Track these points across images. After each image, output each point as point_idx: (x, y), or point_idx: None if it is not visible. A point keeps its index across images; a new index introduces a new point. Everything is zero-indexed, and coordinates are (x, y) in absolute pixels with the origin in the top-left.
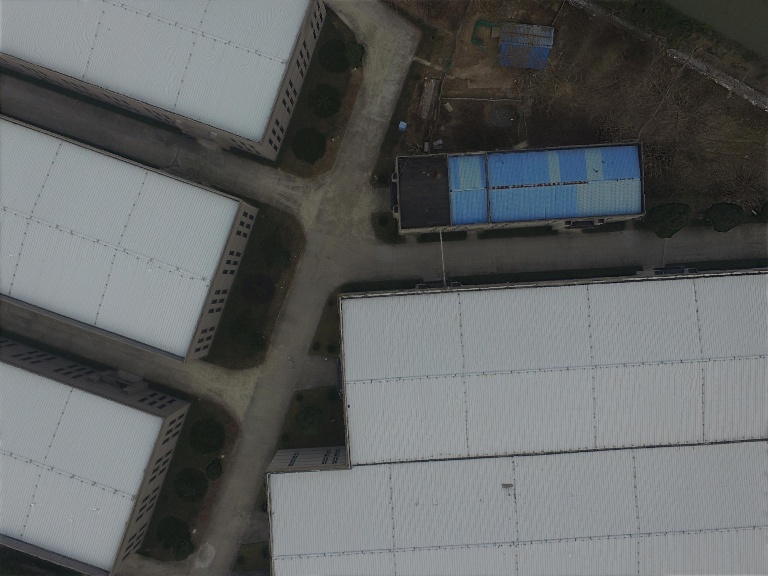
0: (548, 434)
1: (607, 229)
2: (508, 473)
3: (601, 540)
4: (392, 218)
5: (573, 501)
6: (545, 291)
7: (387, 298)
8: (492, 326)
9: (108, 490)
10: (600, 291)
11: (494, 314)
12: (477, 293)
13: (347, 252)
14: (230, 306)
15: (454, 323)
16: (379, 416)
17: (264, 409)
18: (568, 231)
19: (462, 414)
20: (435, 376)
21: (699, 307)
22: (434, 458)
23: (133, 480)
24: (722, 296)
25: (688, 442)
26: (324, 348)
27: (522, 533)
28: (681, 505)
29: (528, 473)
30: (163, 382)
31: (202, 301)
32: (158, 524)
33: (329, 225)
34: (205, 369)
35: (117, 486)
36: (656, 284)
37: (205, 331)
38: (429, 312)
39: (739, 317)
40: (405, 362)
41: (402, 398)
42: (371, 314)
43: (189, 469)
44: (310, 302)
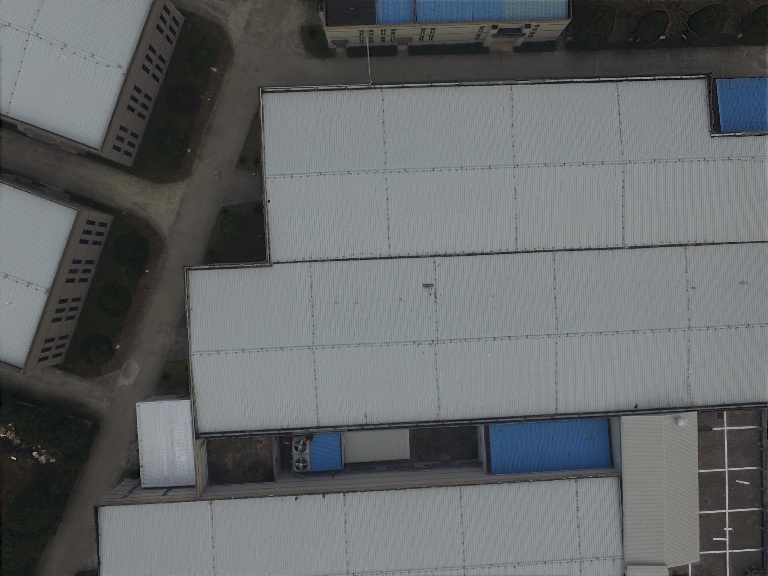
0: (469, 234)
1: (538, 48)
2: (429, 273)
3: (520, 340)
4: (322, 31)
5: (493, 301)
6: (469, 90)
7: (309, 93)
8: (415, 124)
9: (21, 283)
10: (524, 92)
11: (417, 112)
12: (401, 90)
13: (276, 65)
14: (155, 117)
15: (377, 120)
16: (300, 212)
17: (190, 224)
18: (500, 50)
19: (383, 212)
20: (356, 172)
21: (621, 110)
22: (355, 257)
23: (47, 273)
24: (646, 107)
25: (608, 246)
26: (251, 163)
27: (442, 332)
28: (599, 307)
29: (449, 273)
30: (86, 195)
31: (119, 90)
32: (80, 339)
33: (258, 37)
34: (129, 182)
35: (30, 279)
36: (580, 86)
37: (125, 130)
38: (352, 108)
39: (662, 127)
40: (326, 157)
41: (323, 194)
42: (293, 109)
43: (112, 283)
44: (238, 116)
